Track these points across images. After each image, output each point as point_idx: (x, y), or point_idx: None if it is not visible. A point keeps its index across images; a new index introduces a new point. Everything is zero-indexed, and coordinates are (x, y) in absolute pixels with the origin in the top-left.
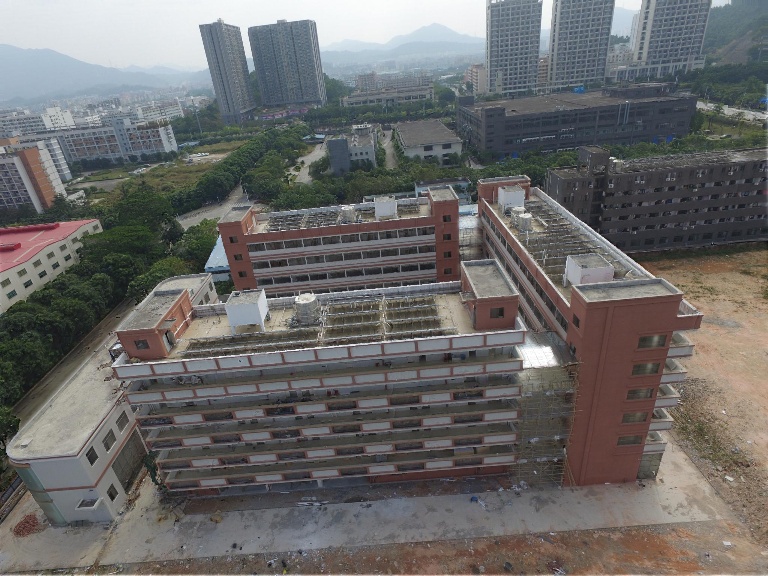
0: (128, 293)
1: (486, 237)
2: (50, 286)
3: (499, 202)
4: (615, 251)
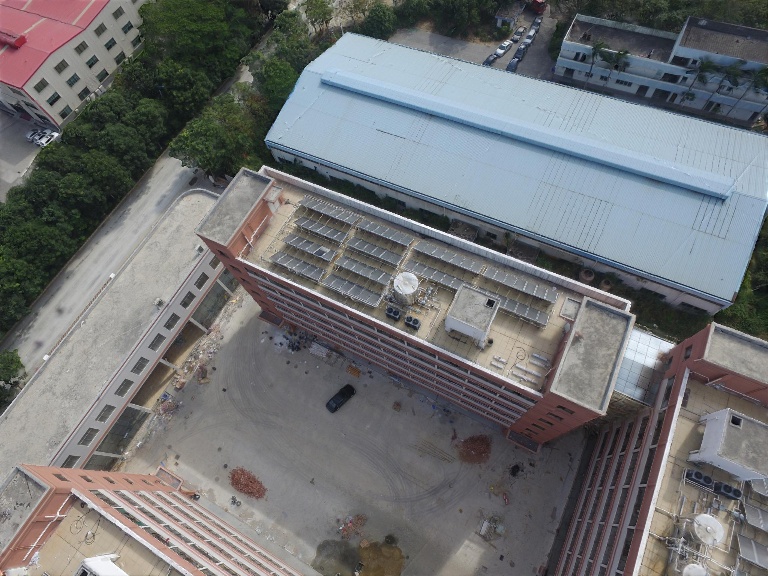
0: (170, 152)
1: (645, 418)
2: (88, 114)
3: (706, 423)
4: None
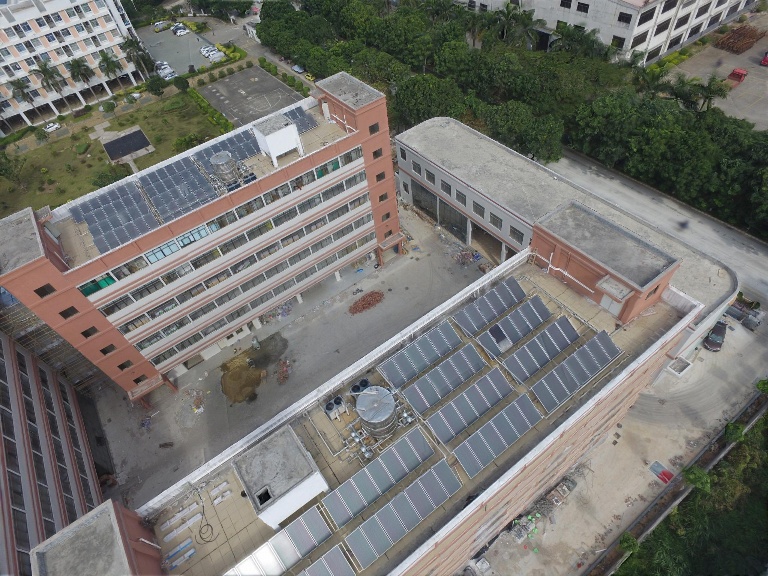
0: None
1: None
2: None
3: None
4: None
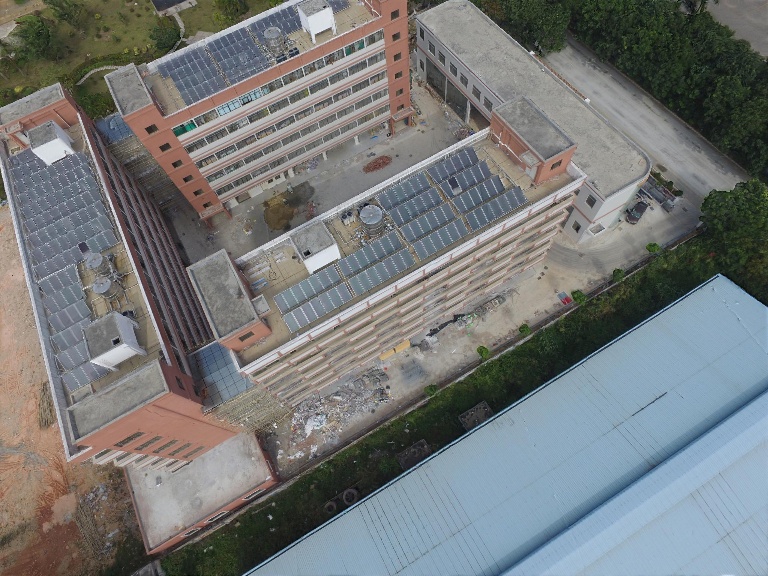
0: None
1: None
2: None
3: None
4: (17, 212)
